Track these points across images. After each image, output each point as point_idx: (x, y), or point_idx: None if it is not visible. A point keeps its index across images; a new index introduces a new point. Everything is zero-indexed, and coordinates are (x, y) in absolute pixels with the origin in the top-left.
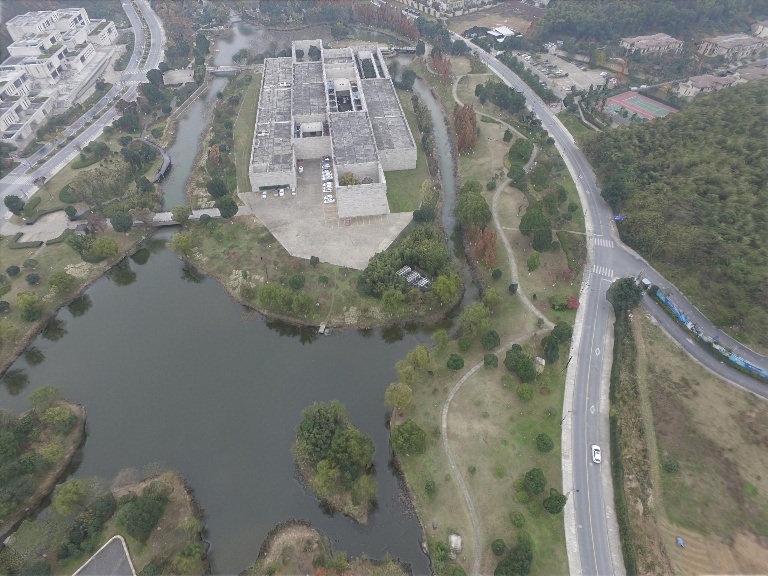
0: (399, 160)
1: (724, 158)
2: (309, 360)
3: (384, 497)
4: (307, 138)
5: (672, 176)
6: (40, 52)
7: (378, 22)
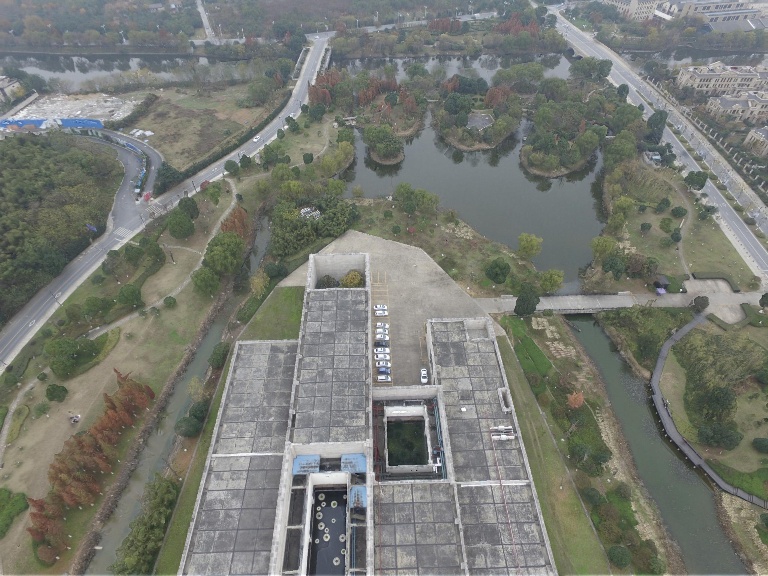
0: None
1: None
2: None
3: (362, 151)
4: (413, 386)
5: None
6: None
7: None
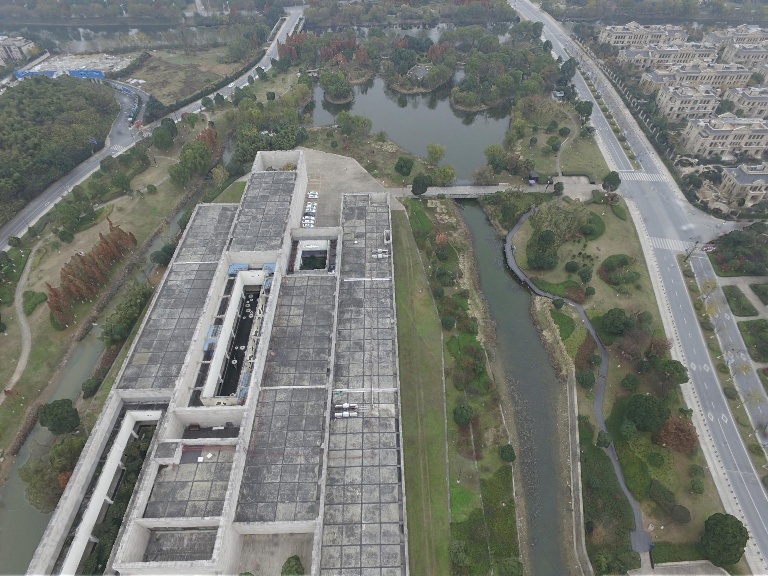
0: None
1: None
2: None
3: None
4: (321, 227)
5: (5, 151)
6: None
7: None
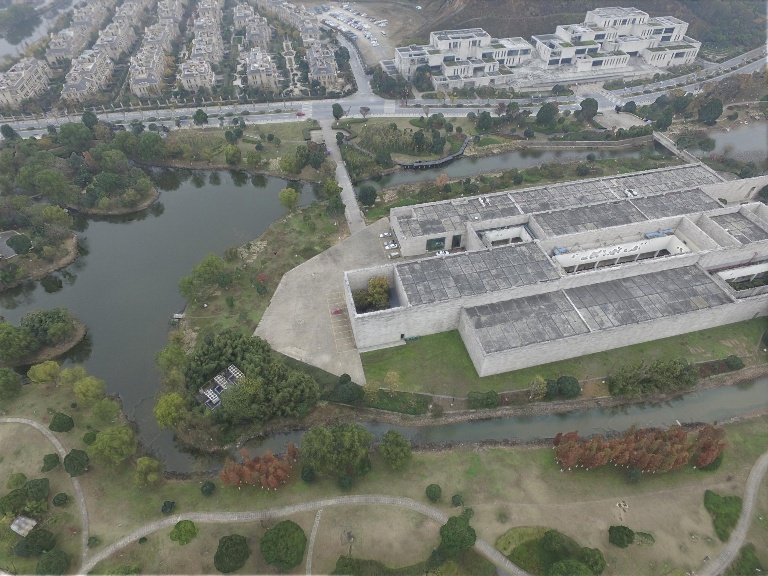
0: (472, 345)
1: None
2: (145, 313)
3: None
4: (476, 235)
5: None
6: (570, 40)
7: None
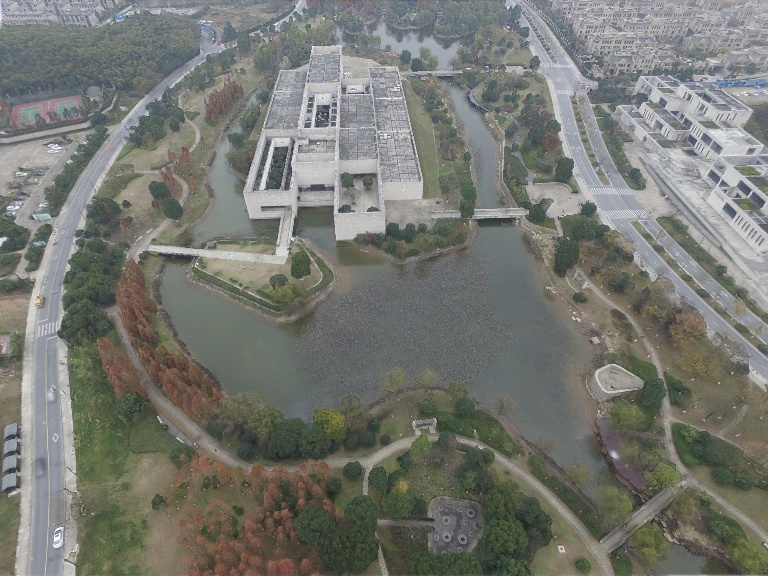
0: None
1: (108, 41)
2: None
3: None
4: (359, 78)
5: None
6: (765, 173)
7: None
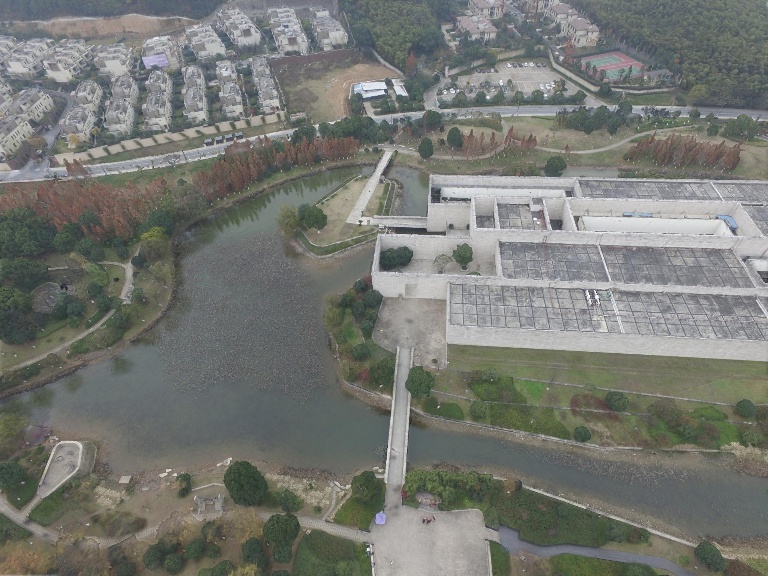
0: None
1: None
2: None
3: None
4: None
5: None
6: None
7: (257, 175)
